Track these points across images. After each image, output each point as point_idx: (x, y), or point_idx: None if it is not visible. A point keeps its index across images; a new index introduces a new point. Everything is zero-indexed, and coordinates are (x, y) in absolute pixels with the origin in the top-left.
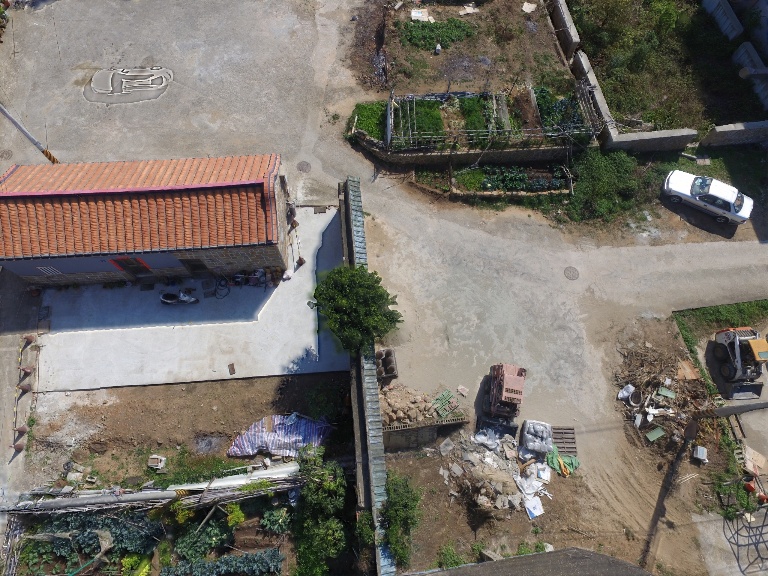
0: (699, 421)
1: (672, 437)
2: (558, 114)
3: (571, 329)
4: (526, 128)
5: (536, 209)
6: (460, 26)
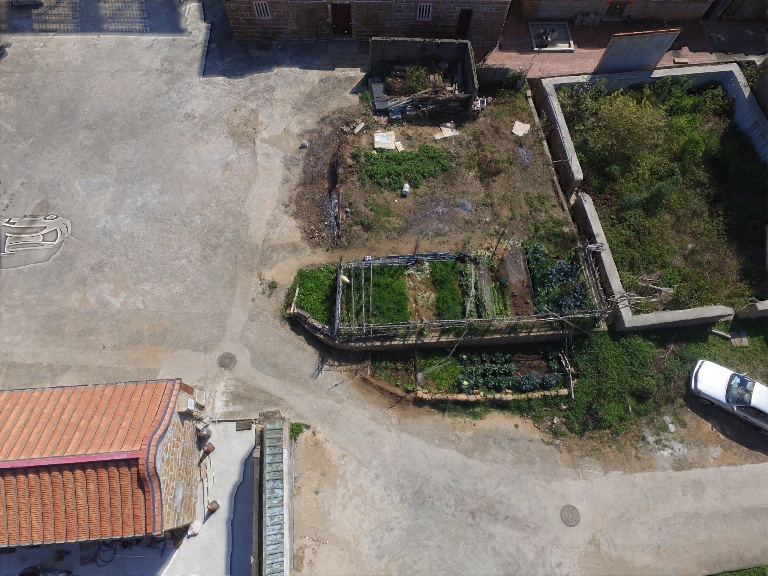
0: None
1: None
2: (555, 285)
3: None
4: (514, 304)
5: (525, 415)
6: (434, 156)
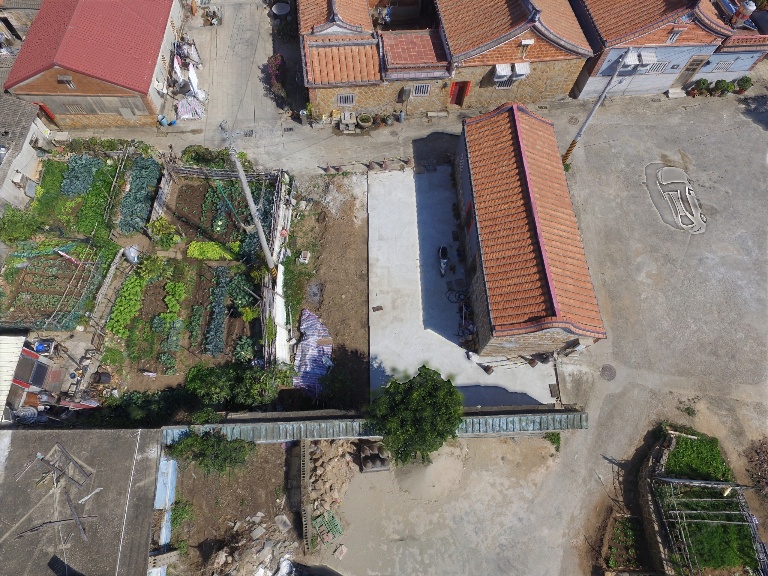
0: None
1: None
2: None
3: None
4: None
5: None
6: None
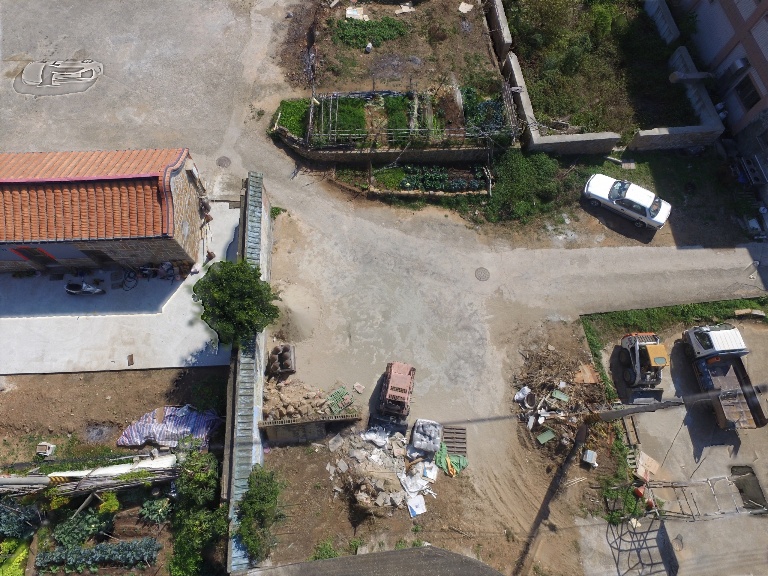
0: (593, 425)
1: (561, 440)
2: (482, 115)
3: (475, 330)
4: (449, 128)
5: (454, 209)
6: (393, 25)
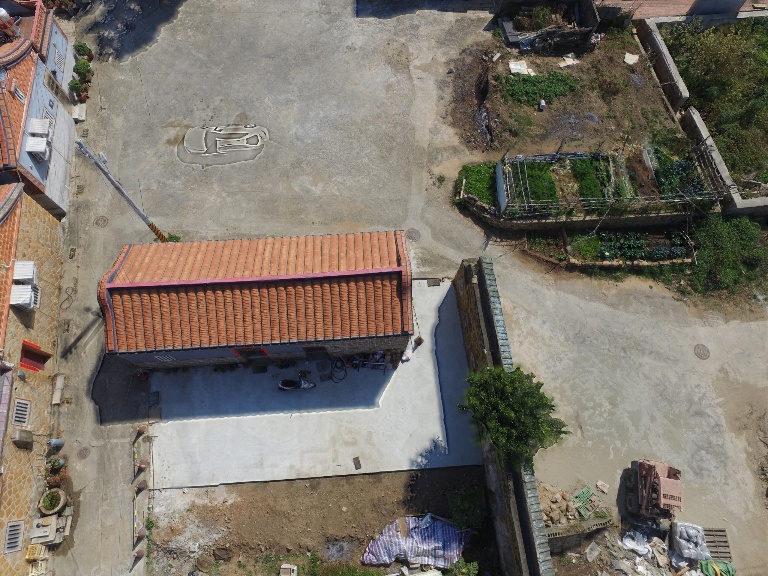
0: None
1: None
2: (675, 177)
3: (709, 415)
4: (642, 192)
5: (657, 279)
6: (562, 80)
